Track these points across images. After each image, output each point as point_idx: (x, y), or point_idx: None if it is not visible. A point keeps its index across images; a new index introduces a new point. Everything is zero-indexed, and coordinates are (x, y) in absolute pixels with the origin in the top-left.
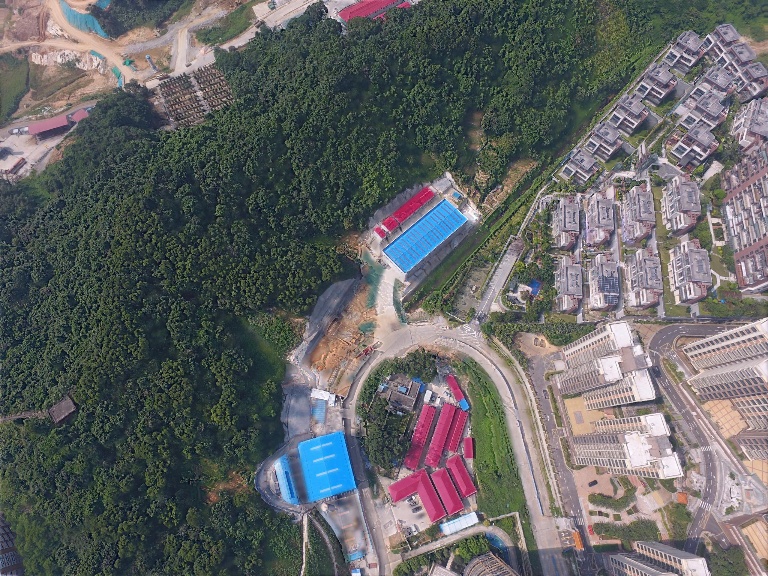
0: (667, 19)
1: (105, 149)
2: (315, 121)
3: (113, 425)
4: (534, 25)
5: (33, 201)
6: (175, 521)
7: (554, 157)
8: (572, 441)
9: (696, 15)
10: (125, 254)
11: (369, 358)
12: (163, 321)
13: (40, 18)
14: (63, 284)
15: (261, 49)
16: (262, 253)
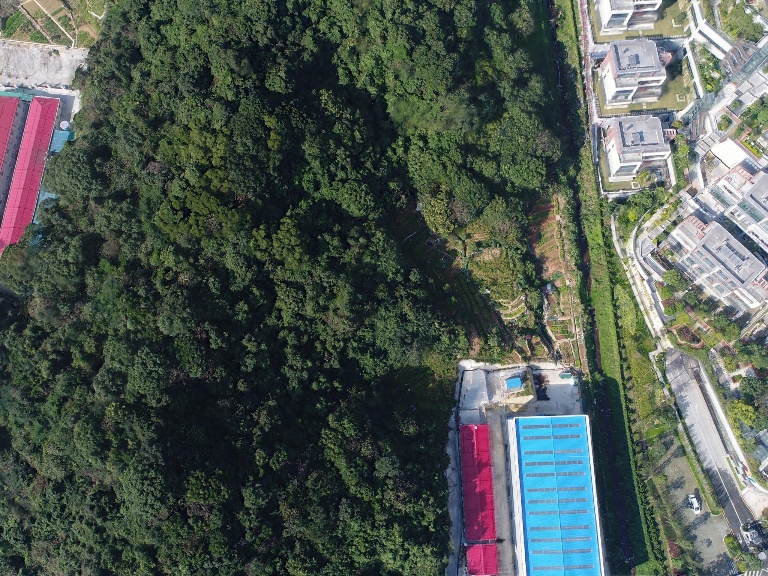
0: None
1: None
2: None
3: None
4: None
5: None
6: None
7: (573, 158)
8: None
9: None
10: None
11: None
12: None
13: None
14: None
15: None
16: None
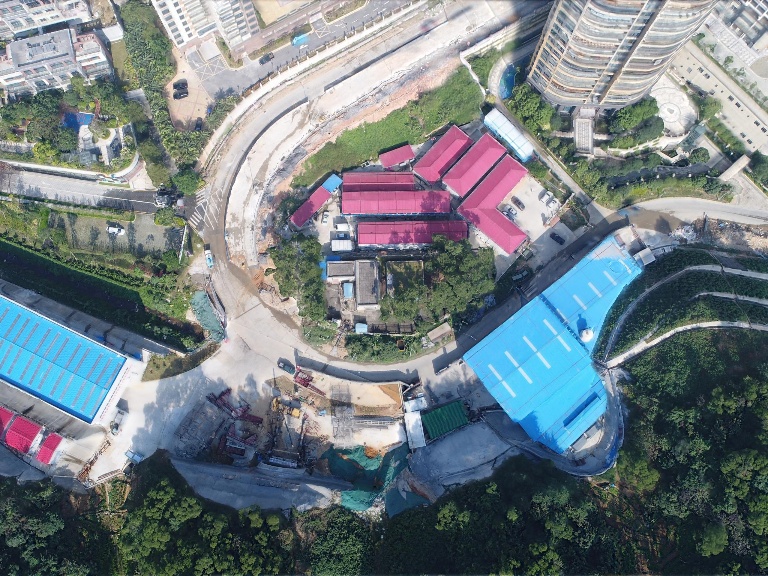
0: None
1: None
2: None
3: None
4: None
5: None
6: (736, 569)
7: None
8: None
9: None
10: None
11: (316, 371)
12: None
13: None
14: None
15: None
16: None
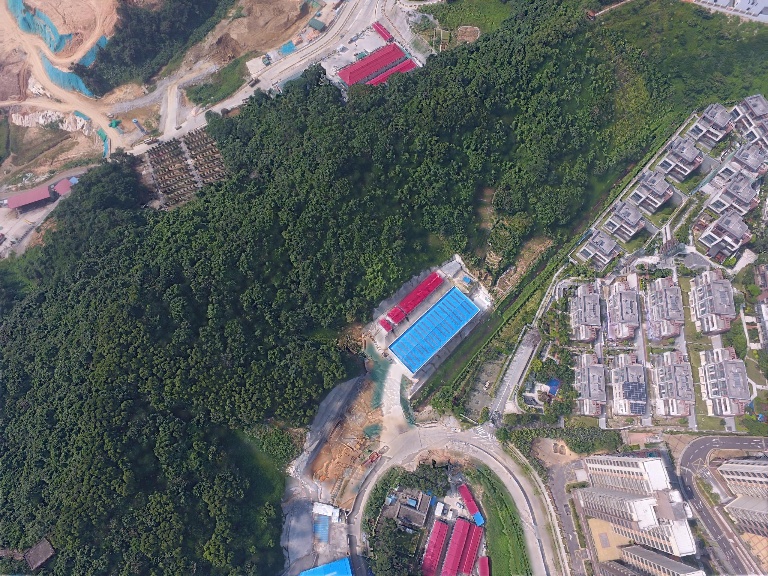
0: (690, 85)
1: (88, 238)
2: (314, 210)
3: (96, 571)
4: (549, 97)
5: (11, 292)
6: None
7: (570, 235)
8: (598, 569)
9: (721, 81)
10: (108, 371)
11: (375, 466)
12: (151, 443)
13: (21, 75)
14: (42, 398)
15: (255, 117)
16: (258, 356)
